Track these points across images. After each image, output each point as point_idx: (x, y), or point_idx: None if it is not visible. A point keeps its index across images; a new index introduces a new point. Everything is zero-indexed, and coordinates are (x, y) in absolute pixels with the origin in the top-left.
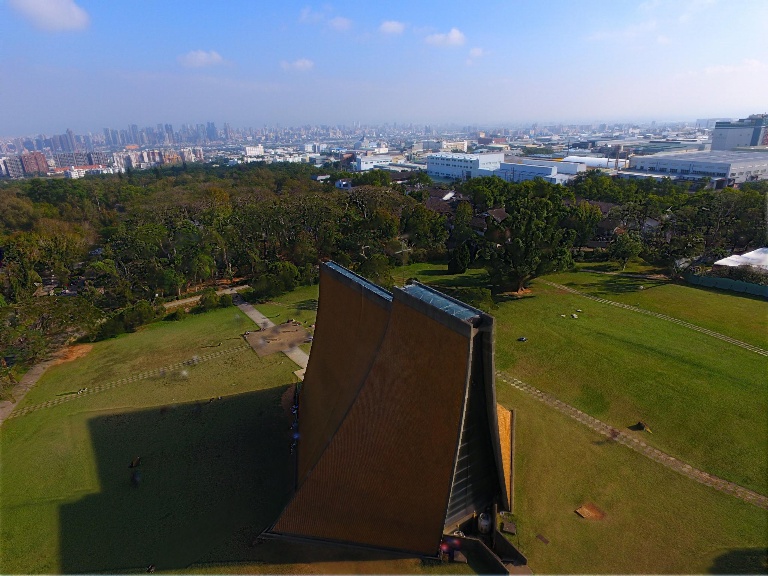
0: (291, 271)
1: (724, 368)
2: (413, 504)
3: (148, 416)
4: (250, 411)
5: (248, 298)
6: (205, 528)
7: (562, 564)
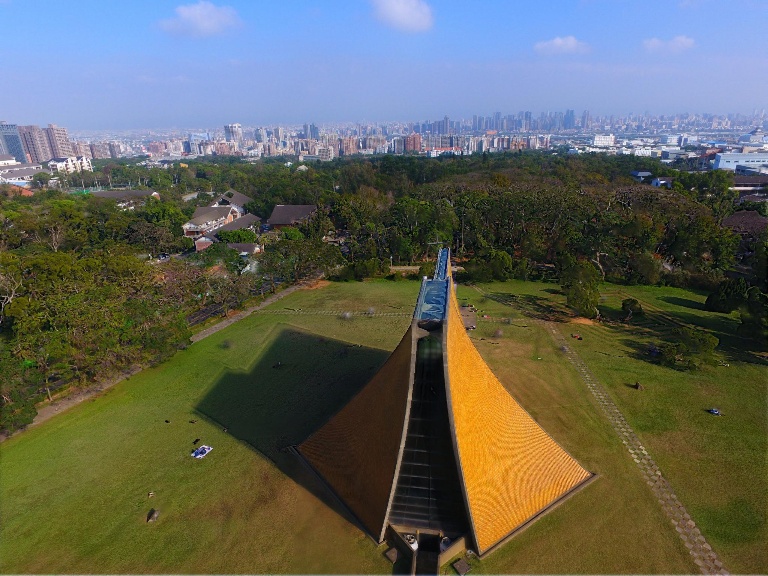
0: (502, 261)
1: None
2: (372, 482)
3: (312, 340)
4: (366, 363)
5: (459, 278)
6: (268, 424)
7: None
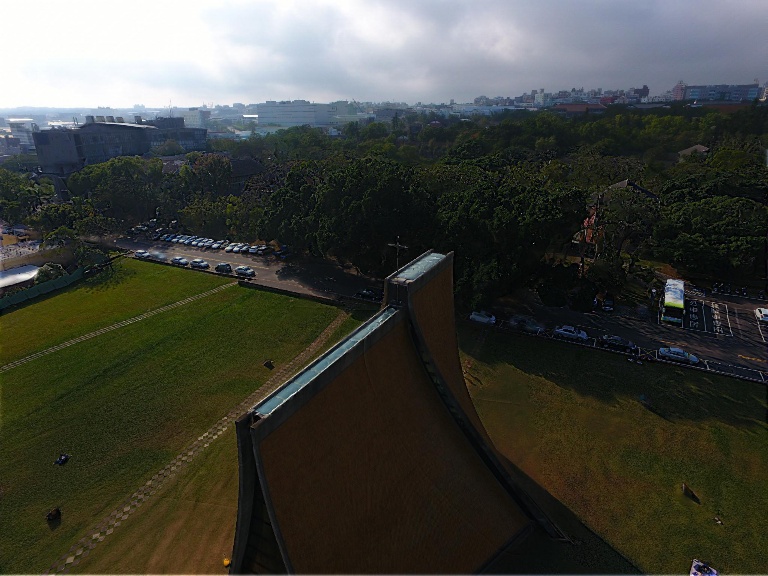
0: None
1: (164, 334)
2: None
3: None
4: None
5: None
6: None
7: None
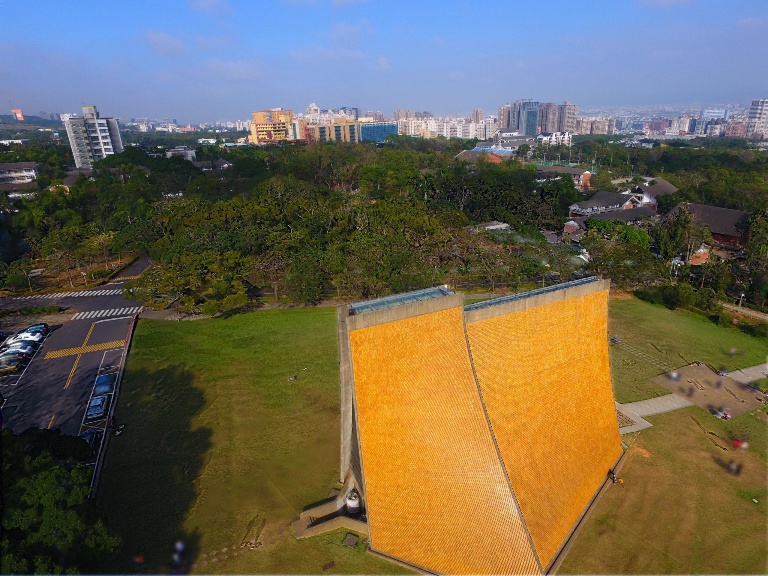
0: None
1: None
2: None
3: None
4: None
5: None
6: None
7: (297, 569)
